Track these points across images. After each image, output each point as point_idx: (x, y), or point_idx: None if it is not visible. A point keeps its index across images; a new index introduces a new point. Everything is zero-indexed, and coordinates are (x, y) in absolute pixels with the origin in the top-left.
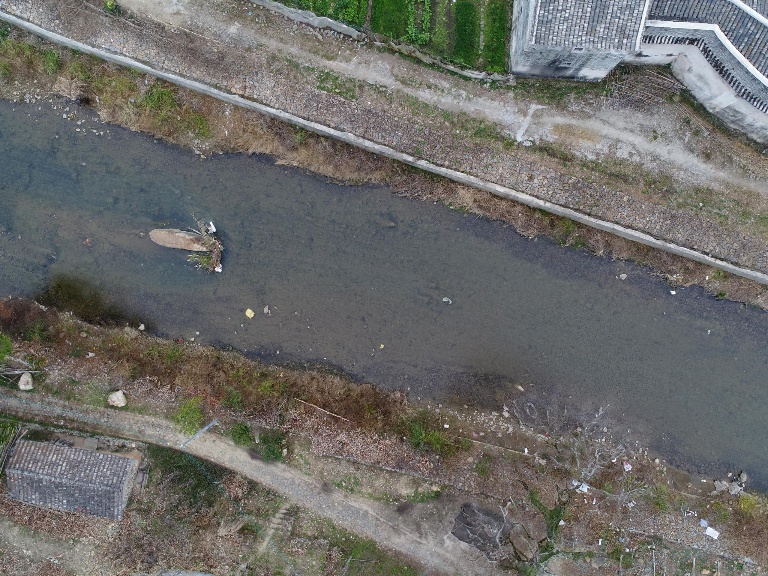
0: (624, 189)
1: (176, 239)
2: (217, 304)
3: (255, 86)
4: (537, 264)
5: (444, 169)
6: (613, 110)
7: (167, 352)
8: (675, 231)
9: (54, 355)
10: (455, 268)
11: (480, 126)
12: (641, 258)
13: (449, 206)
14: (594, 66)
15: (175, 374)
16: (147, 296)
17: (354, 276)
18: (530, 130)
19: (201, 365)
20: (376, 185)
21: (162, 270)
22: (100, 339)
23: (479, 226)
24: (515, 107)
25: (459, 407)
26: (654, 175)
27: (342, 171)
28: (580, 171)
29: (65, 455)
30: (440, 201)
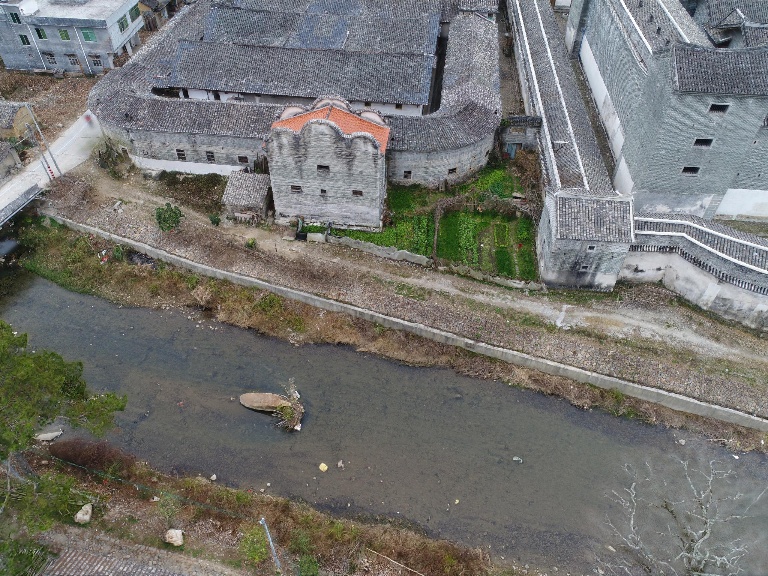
0: (656, 359)
1: (265, 398)
2: (292, 459)
3: (347, 293)
4: (597, 431)
5: (500, 349)
6: (628, 309)
7: (237, 495)
8: (714, 393)
9: (119, 496)
10: (520, 433)
11: (526, 316)
12: (693, 425)
13: (507, 383)
14: (605, 270)
15: (240, 520)
16: (225, 450)
17: (425, 437)
18: (566, 320)
19: (268, 512)
20: (442, 367)
21: (244, 429)
22: (170, 485)
23: (537, 400)
24: (551, 306)
25: (548, 569)
26: (678, 349)
27: (413, 355)
28: (615, 347)
29: (114, 567)
30: (499, 380)
